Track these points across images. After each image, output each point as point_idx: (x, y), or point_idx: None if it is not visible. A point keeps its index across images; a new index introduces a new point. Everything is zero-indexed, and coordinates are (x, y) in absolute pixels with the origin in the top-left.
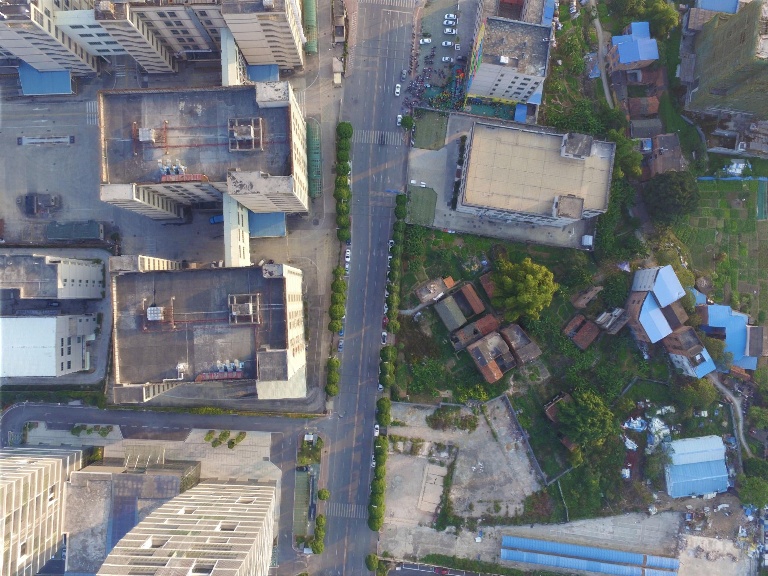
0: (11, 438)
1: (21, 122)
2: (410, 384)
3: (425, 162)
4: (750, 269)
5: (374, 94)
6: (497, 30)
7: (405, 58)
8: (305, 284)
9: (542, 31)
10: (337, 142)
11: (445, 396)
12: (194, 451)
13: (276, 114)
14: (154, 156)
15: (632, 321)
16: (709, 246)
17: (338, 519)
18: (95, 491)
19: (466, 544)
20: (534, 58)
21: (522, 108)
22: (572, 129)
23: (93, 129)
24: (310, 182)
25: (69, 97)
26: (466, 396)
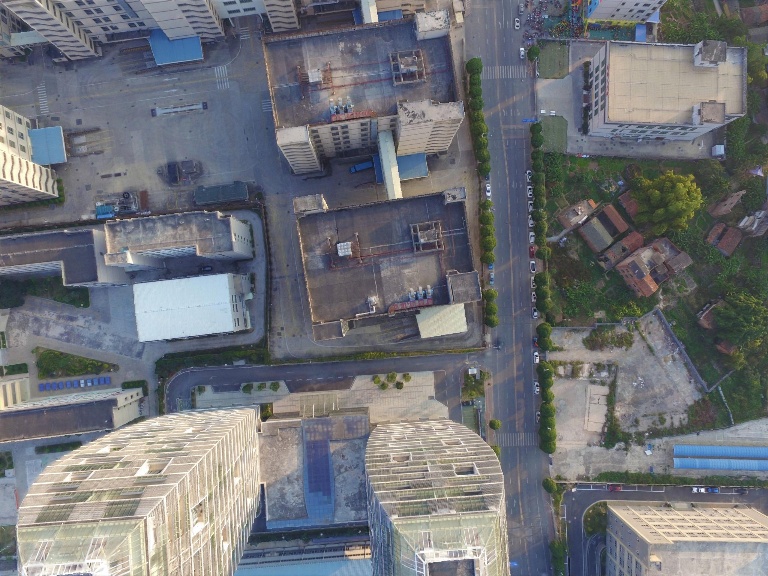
0: (180, 405)
1: (153, 94)
2: (565, 308)
3: (552, 91)
4: None
5: (494, 30)
6: None
7: None
8: None
9: None
10: (464, 81)
11: (599, 317)
12: (361, 398)
13: (434, 45)
14: (321, 98)
15: None
16: None
17: (508, 449)
18: (286, 439)
19: (637, 458)
20: None
21: (641, 28)
22: (693, 43)
23: (224, 93)
24: None
25: (197, 64)
26: (622, 313)
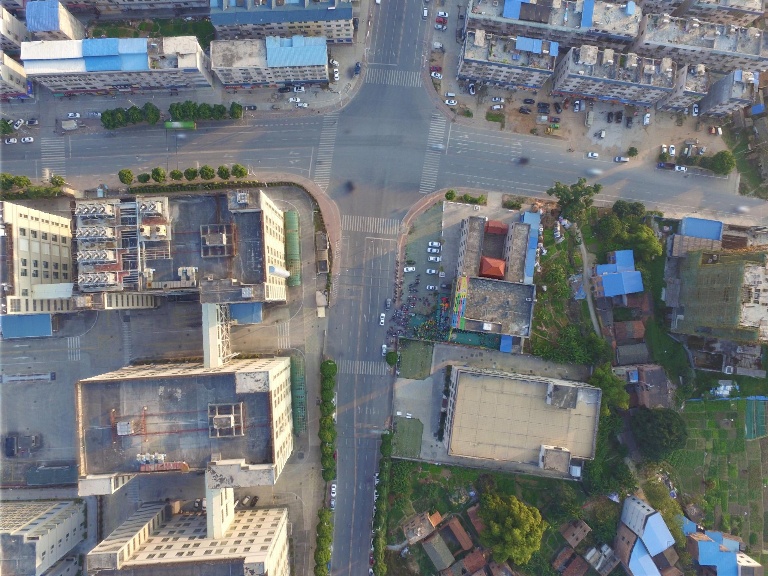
0: None
1: (1, 359)
2: None
3: (411, 392)
4: (740, 490)
5: (358, 323)
6: (480, 289)
7: (389, 286)
8: (290, 524)
9: (525, 289)
10: (322, 374)
11: None
12: None
13: (257, 397)
14: (133, 443)
15: (622, 560)
16: (698, 468)
17: None
18: None
19: None
20: (517, 317)
21: (507, 338)
22: (558, 361)
23: (74, 365)
24: (294, 418)
25: None
26: None
